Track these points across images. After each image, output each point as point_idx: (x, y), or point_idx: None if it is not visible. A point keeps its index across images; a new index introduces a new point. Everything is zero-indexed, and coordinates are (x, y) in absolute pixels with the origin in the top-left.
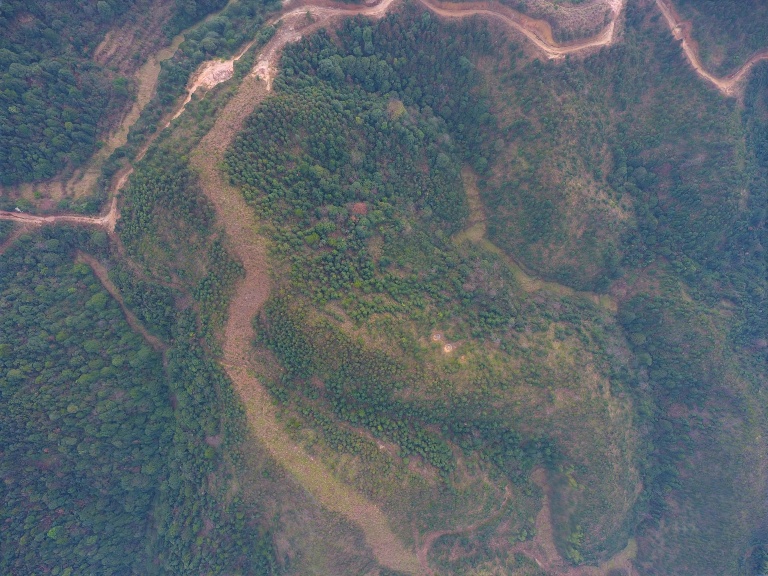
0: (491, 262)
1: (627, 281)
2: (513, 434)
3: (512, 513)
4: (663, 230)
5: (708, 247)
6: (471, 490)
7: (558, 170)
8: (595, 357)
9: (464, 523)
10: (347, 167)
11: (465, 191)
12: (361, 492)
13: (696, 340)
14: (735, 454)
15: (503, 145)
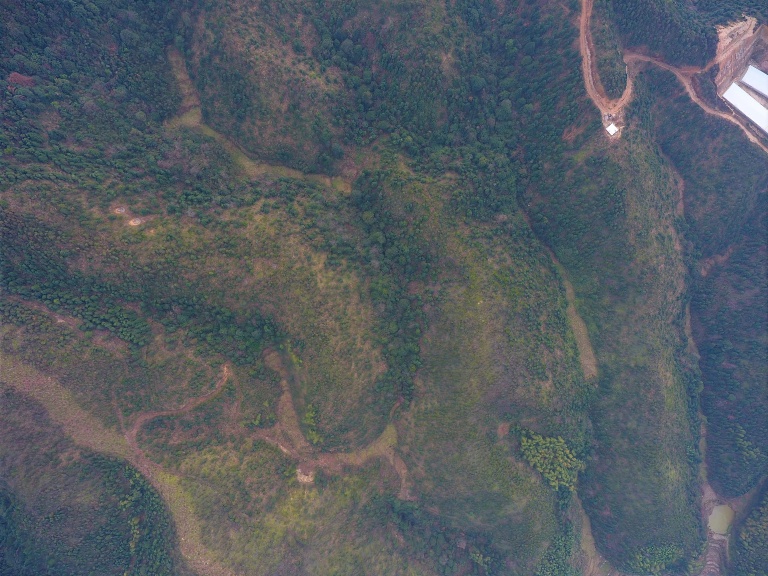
0: (199, 143)
1: (355, 160)
2: (217, 309)
3: (238, 395)
4: (379, 104)
5: (429, 119)
6: (167, 364)
7: (239, 37)
8: (301, 228)
9: (171, 401)
10: (6, 39)
11: (175, 75)
12: (26, 362)
13: (416, 211)
14: (458, 321)
15: (189, 18)
